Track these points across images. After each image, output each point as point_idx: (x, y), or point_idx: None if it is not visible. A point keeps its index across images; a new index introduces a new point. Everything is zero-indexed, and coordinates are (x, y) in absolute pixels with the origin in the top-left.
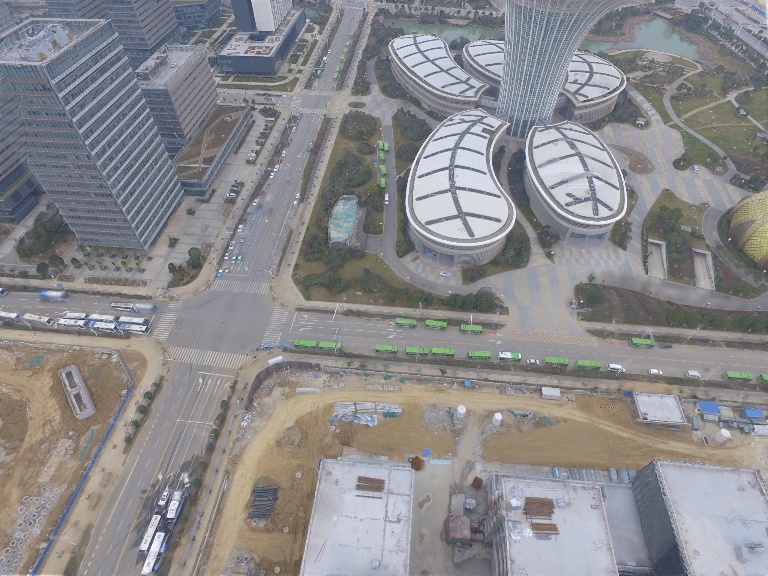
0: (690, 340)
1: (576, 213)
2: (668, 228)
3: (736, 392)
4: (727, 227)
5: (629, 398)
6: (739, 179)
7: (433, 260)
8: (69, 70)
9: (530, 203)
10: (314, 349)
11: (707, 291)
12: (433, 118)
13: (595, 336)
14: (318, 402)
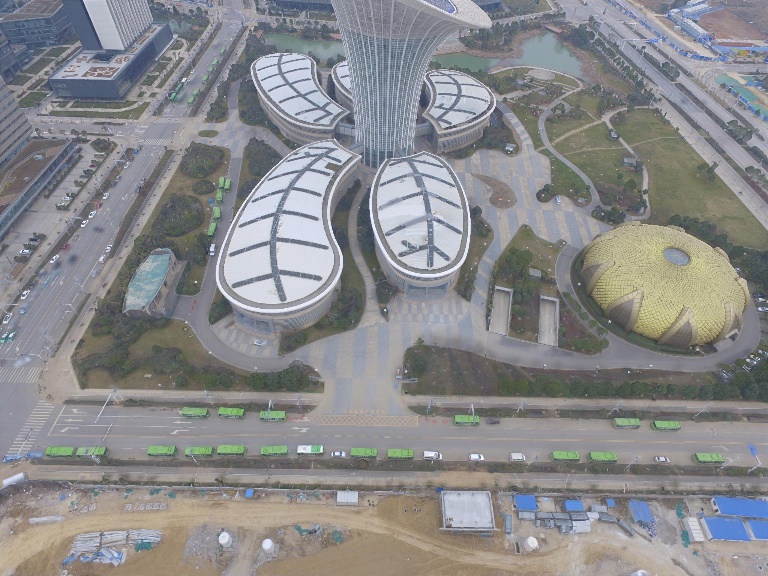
0: (521, 412)
1: (409, 265)
2: (515, 274)
3: (562, 476)
4: (580, 268)
5: (440, 495)
6: (600, 211)
7: (250, 325)
8: None
9: (375, 248)
10: (72, 457)
11: (549, 348)
12: (290, 148)
13: (417, 414)
14: (55, 536)
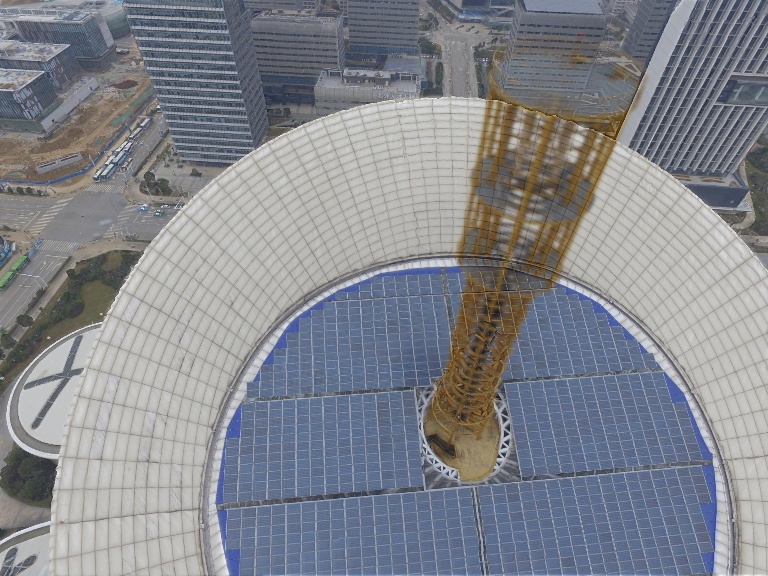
0: None
1: None
2: None
3: None
4: None
5: None
6: None
7: None
8: (146, 6)
9: None
10: None
11: None
12: None
13: None
14: None
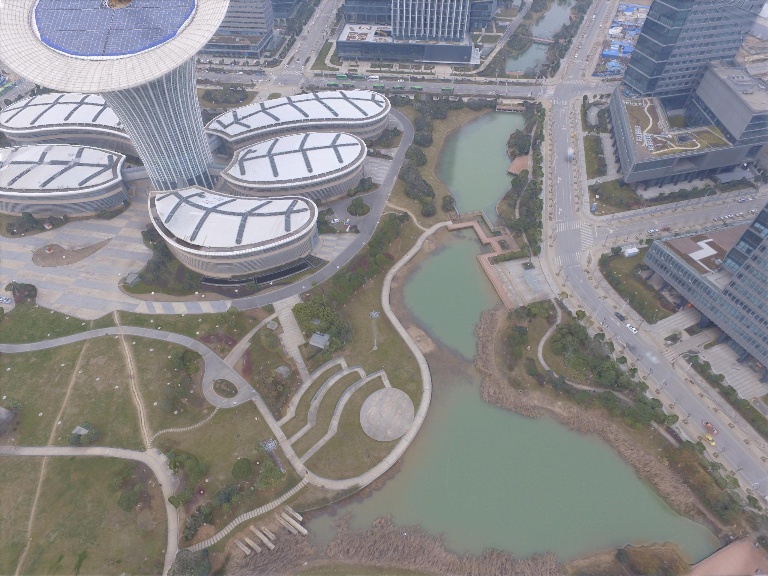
0: None
1: None
2: None
3: None
4: None
5: None
6: None
7: None
8: None
9: None
10: None
11: None
12: None
13: None
14: None
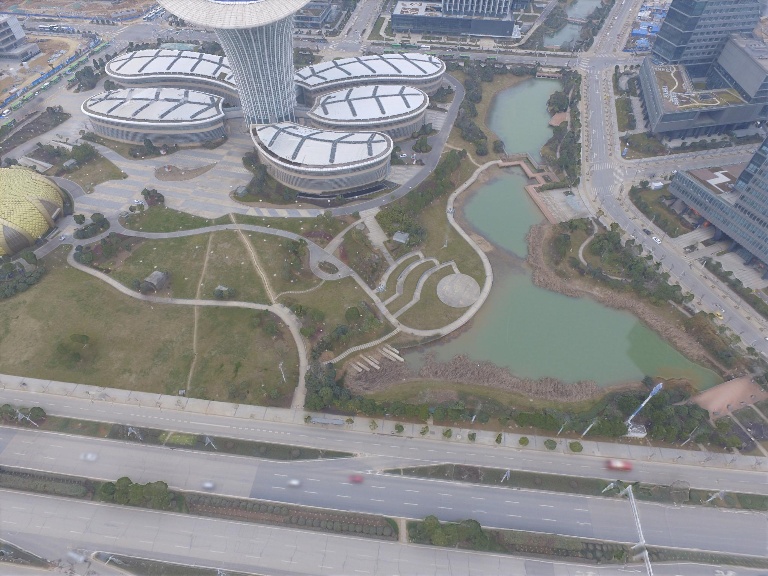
0: None
1: None
2: None
3: None
4: None
5: None
6: None
7: None
8: None
9: None
10: None
11: None
12: None
13: None
14: (72, 48)
